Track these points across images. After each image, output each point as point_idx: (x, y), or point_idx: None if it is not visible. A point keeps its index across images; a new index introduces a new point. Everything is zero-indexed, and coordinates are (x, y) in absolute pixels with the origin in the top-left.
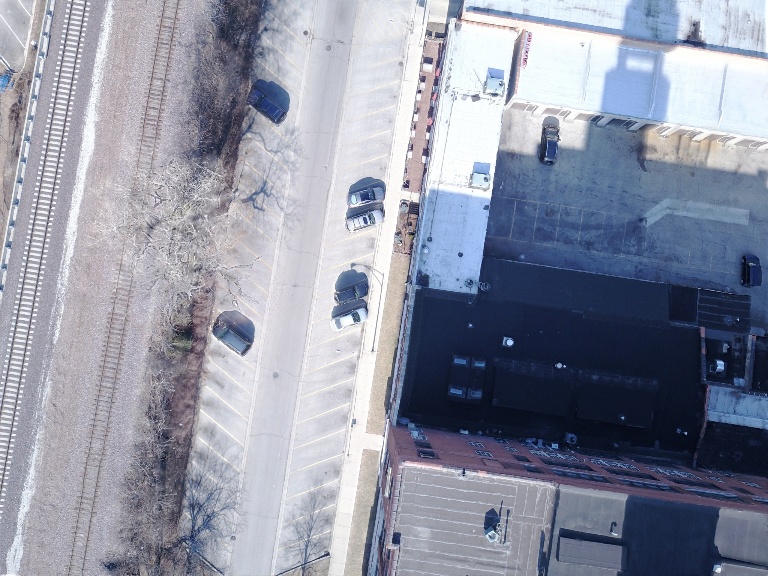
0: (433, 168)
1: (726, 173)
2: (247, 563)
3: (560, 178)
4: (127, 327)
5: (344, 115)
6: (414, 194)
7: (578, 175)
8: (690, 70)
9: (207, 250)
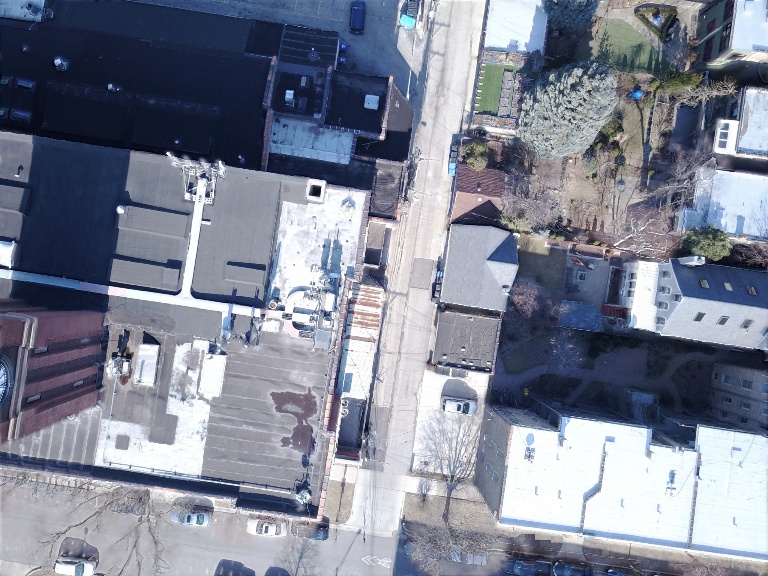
0: None
1: None
2: None
3: None
4: None
5: None
6: None
7: None
8: None
9: None
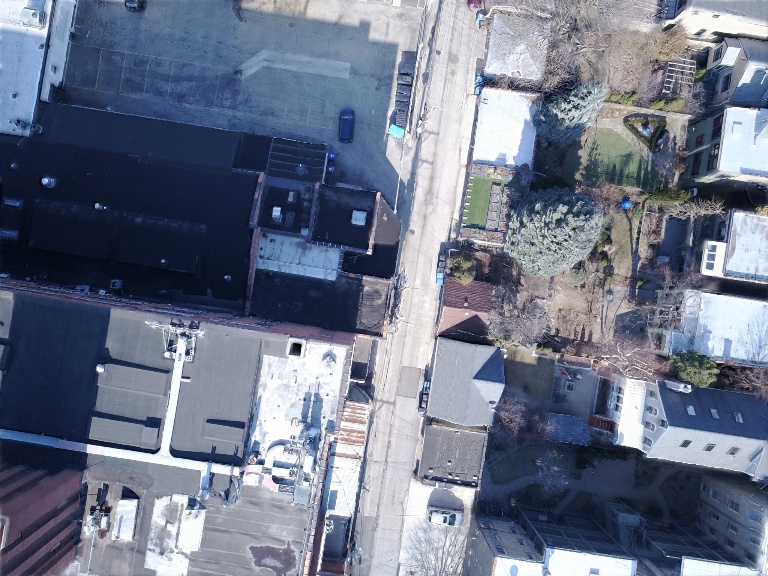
0: None
1: (326, 24)
2: None
3: (150, 27)
4: None
5: None
6: None
7: (169, 24)
8: None
9: None
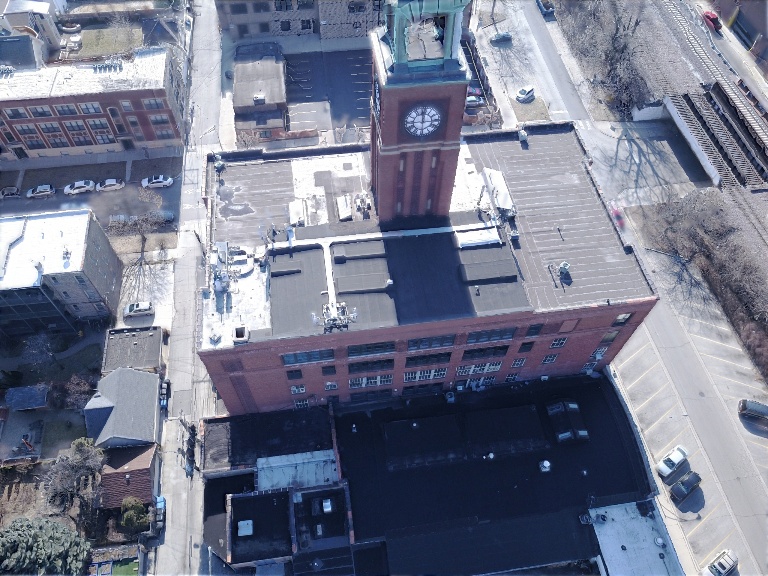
0: None
1: None
2: None
3: None
4: None
5: None
6: None
7: None
8: None
9: None
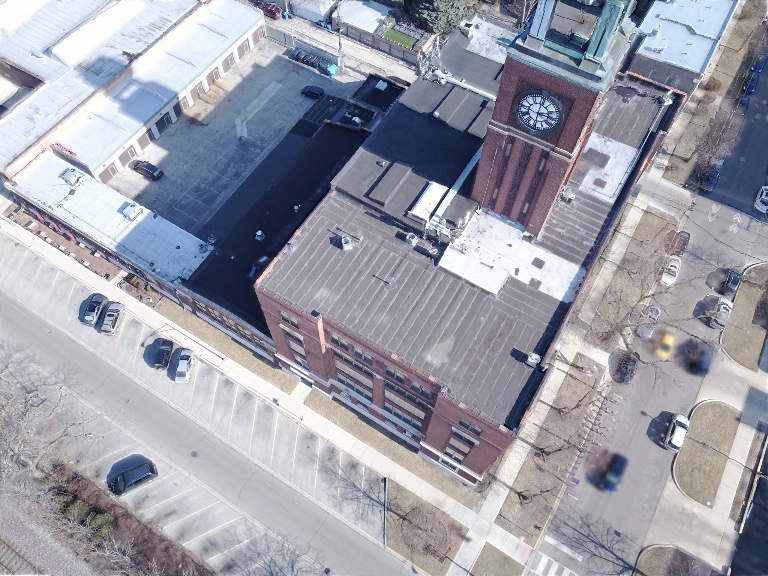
0: (100, 240)
1: (240, 84)
2: (358, 567)
3: (177, 174)
4: (48, 574)
5: (20, 301)
6: (119, 274)
7: (183, 163)
8: (153, 70)
9: (2, 399)
